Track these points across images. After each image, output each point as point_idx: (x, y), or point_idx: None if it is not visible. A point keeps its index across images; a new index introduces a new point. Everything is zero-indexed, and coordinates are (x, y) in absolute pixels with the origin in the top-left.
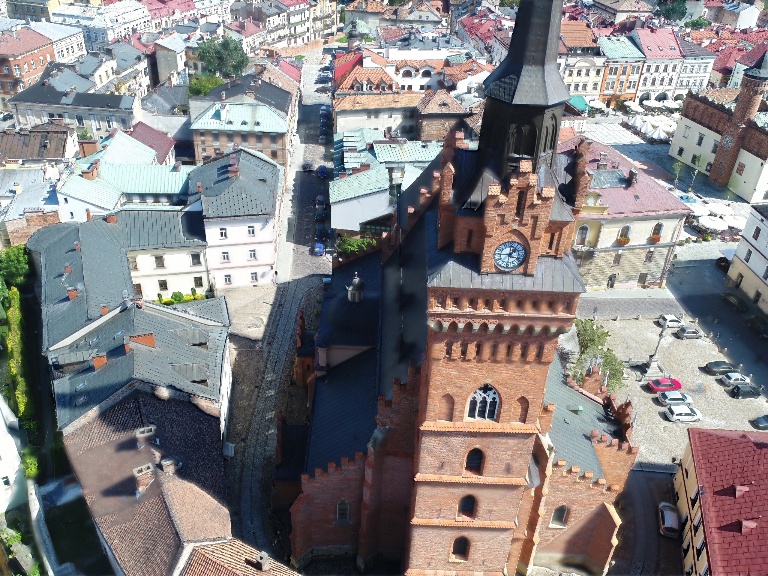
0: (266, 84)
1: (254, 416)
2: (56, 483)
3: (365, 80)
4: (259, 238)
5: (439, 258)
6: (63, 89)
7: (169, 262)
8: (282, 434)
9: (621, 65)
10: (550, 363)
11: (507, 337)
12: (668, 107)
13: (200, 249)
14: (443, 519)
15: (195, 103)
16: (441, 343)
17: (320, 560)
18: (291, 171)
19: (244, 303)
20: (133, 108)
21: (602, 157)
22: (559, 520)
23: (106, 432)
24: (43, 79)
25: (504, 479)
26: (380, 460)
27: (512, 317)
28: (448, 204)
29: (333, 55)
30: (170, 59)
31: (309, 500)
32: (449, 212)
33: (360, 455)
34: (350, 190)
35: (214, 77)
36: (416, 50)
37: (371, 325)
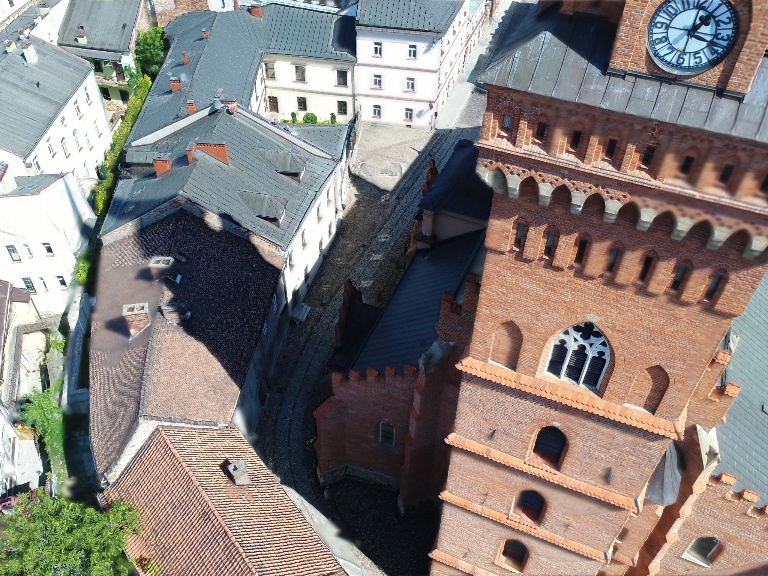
0: None
1: None
2: None
3: None
4: (421, 63)
5: (530, 29)
6: None
7: (311, 76)
8: (348, 311)
9: None
10: (734, 316)
11: (647, 238)
12: None
13: (348, 65)
14: (489, 508)
15: None
16: (505, 220)
17: (355, 482)
18: (506, 1)
19: (387, 144)
20: None
21: None
22: (701, 552)
23: (138, 252)
24: None
25: (596, 489)
26: (436, 386)
27: (664, 193)
28: None
29: None
30: None
31: (341, 407)
32: None
33: (411, 371)
34: None
35: None
36: None
37: None
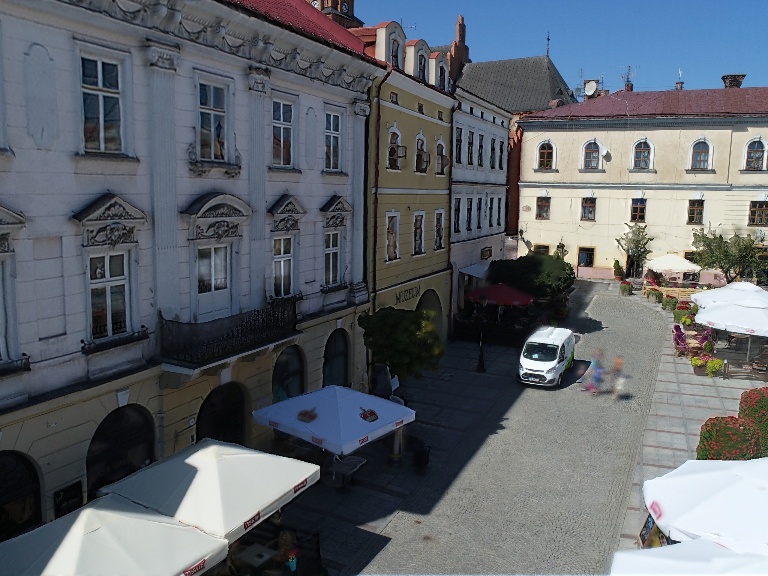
0: None
1: None
2: None
3: None
4: None
5: None
6: None
7: None
8: None
9: None
10: None
11: None
12: None
13: None
14: None
15: None
16: None
17: None
18: None
19: None
20: None
21: None
22: None
23: None
24: None
25: None
26: None
27: None
28: None
29: None
30: None
31: None
32: None
33: None
34: None
35: None
36: None
37: None
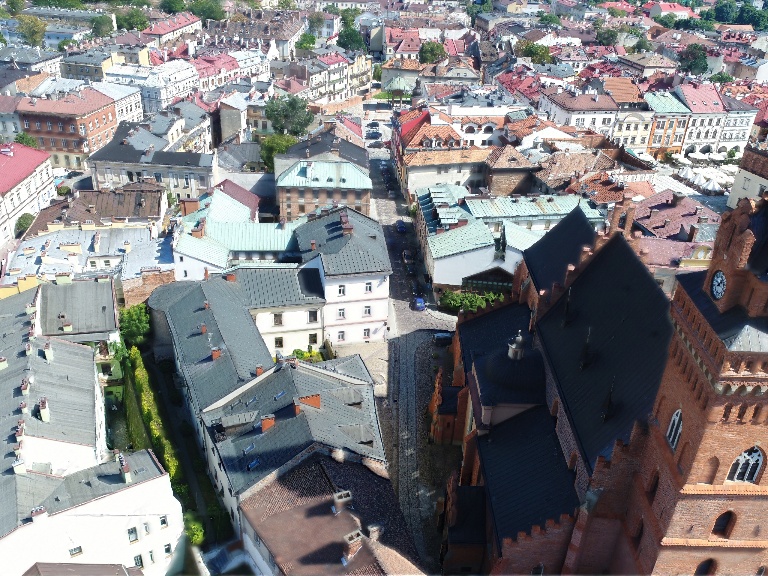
0: (343, 141)
1: (400, 476)
2: (219, 550)
3: (433, 136)
4: (375, 294)
5: (727, 322)
6: (141, 148)
7: (287, 319)
8: None
9: (668, 119)
10: None
11: None
12: (712, 159)
13: (318, 306)
14: None
15: (280, 161)
16: (721, 406)
17: None
18: None
19: None
20: (212, 166)
21: (698, 211)
22: None
23: (290, 497)
24: (118, 138)
25: (750, 542)
26: (589, 523)
27: None
28: (743, 269)
29: (396, 112)
30: (234, 117)
31: (508, 565)
32: (740, 277)
33: (567, 518)
34: (452, 245)
35: (286, 135)
36: (478, 107)
37: (536, 383)
